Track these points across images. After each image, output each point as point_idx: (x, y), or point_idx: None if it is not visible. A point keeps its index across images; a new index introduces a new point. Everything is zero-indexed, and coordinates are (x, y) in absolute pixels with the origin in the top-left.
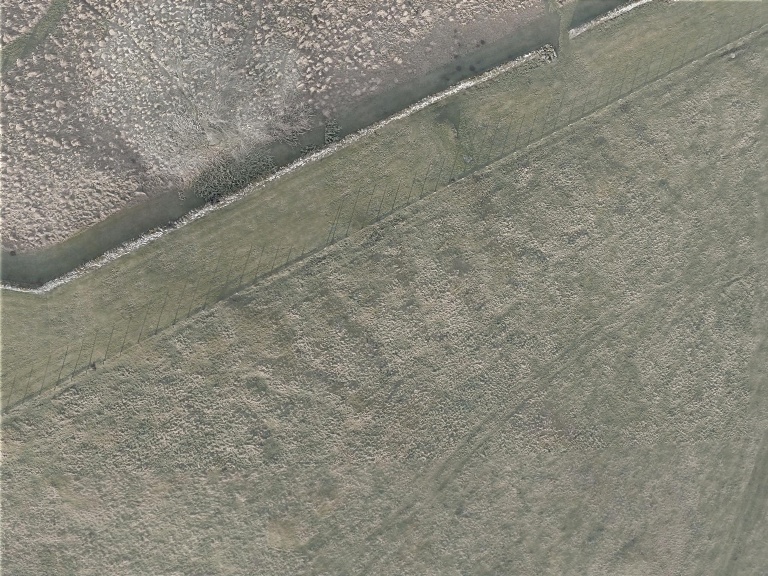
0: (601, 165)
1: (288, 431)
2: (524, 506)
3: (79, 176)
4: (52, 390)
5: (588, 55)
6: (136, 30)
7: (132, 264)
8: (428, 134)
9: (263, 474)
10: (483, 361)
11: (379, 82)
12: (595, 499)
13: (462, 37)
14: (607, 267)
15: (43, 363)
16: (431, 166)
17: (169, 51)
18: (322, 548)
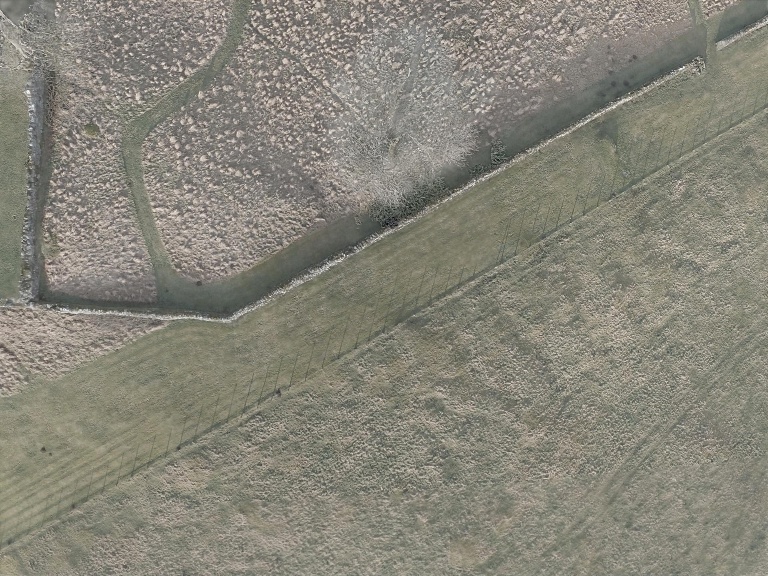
0: (750, 174)
1: (466, 450)
2: (690, 517)
3: (262, 205)
4: (239, 418)
5: (735, 66)
6: (308, 58)
7: (314, 290)
8: (590, 150)
9: (443, 494)
10: (646, 374)
11: (540, 100)
12: (756, 507)
13: (615, 53)
14: (758, 275)
15: (229, 391)
16: (593, 182)
17: (340, 78)
18: (500, 566)
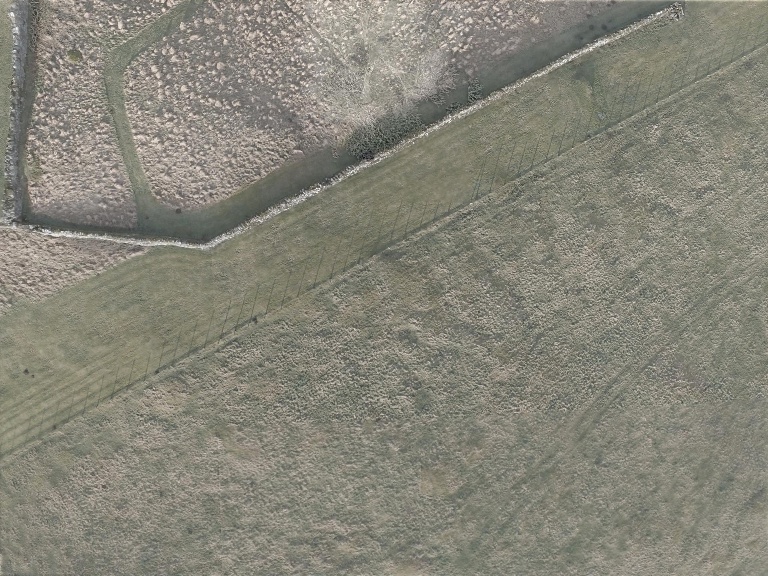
0: (727, 121)
1: (438, 382)
2: (659, 456)
3: (241, 135)
4: (216, 343)
5: (713, 13)
6: None
7: (291, 220)
8: (566, 91)
9: (415, 424)
10: (618, 314)
11: (518, 41)
12: (725, 450)
13: None
14: (733, 222)
15: (207, 317)
16: (568, 123)
17: (320, 13)
18: (470, 497)
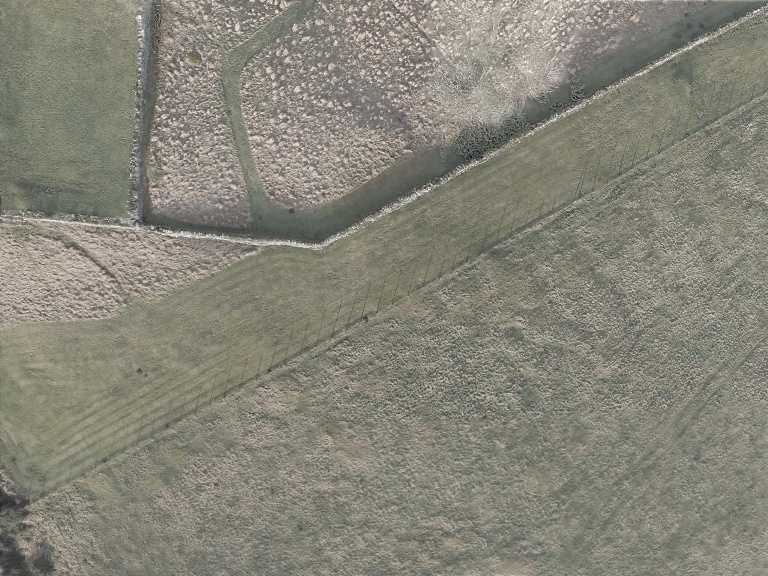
0: None
1: (543, 379)
2: (756, 452)
3: (353, 135)
4: (327, 342)
5: None
6: None
7: (401, 219)
8: (666, 90)
9: (521, 421)
10: (716, 311)
11: (618, 40)
12: None
13: None
14: None
15: (319, 316)
16: (668, 121)
17: (427, 14)
18: (574, 493)
